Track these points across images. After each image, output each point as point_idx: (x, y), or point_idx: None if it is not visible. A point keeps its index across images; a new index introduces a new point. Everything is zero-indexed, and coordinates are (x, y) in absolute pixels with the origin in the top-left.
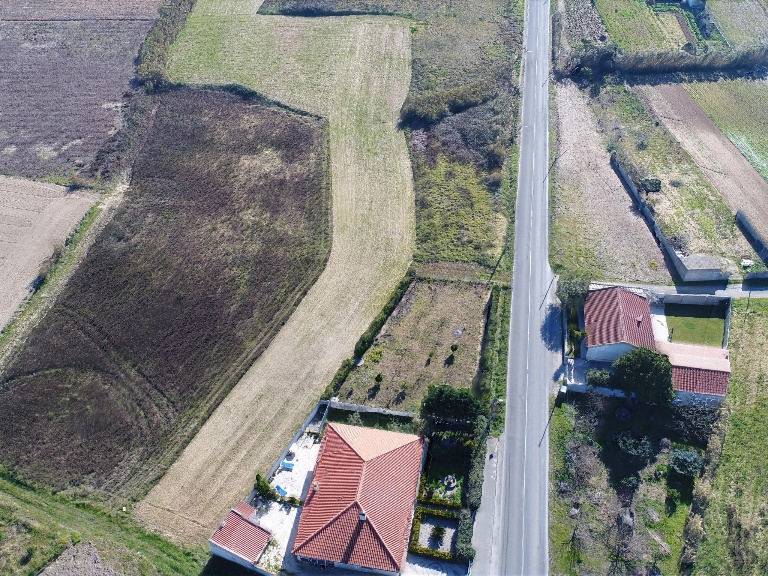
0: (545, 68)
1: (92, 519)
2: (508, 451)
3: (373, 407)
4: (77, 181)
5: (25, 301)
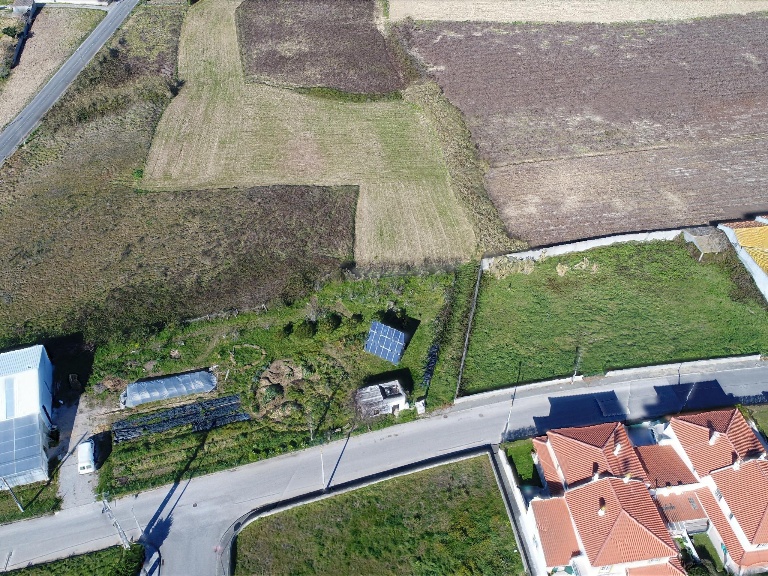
0: (2, 137)
1: None
2: None
3: None
4: None
5: None
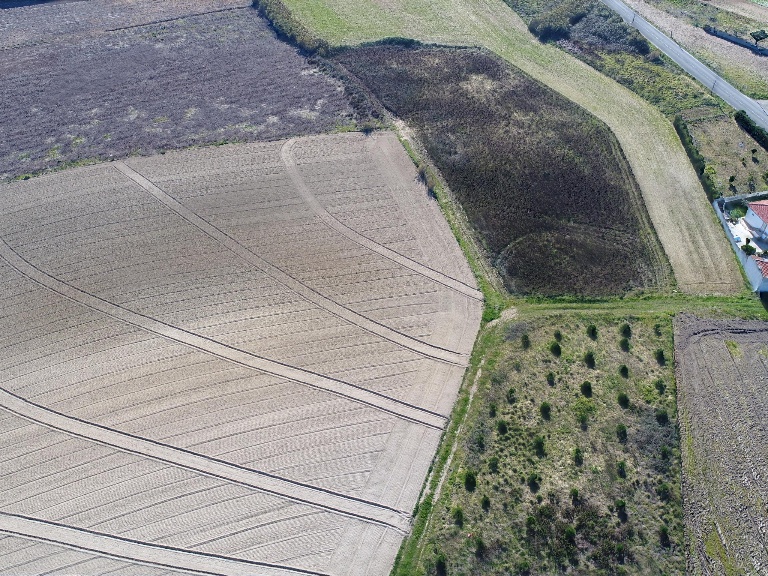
0: None
1: (664, 302)
2: None
3: None
4: (369, 124)
5: (439, 207)
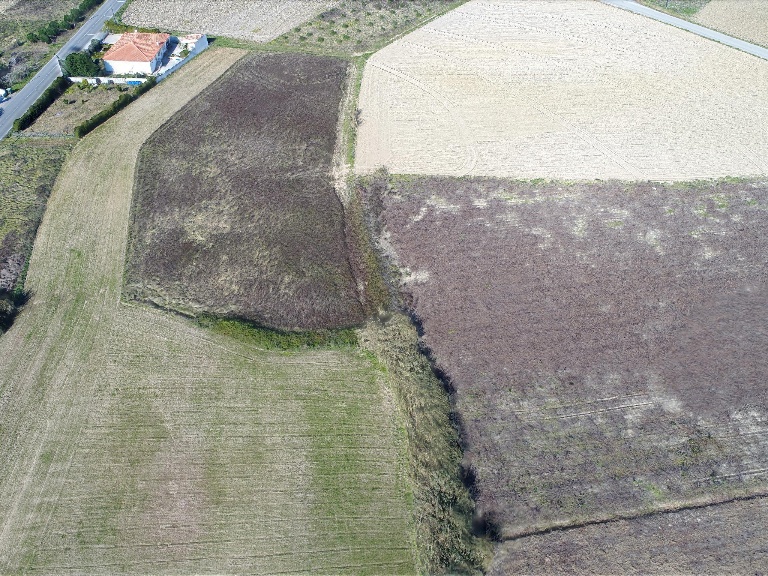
0: None
1: None
2: None
3: (127, 85)
4: None
5: None
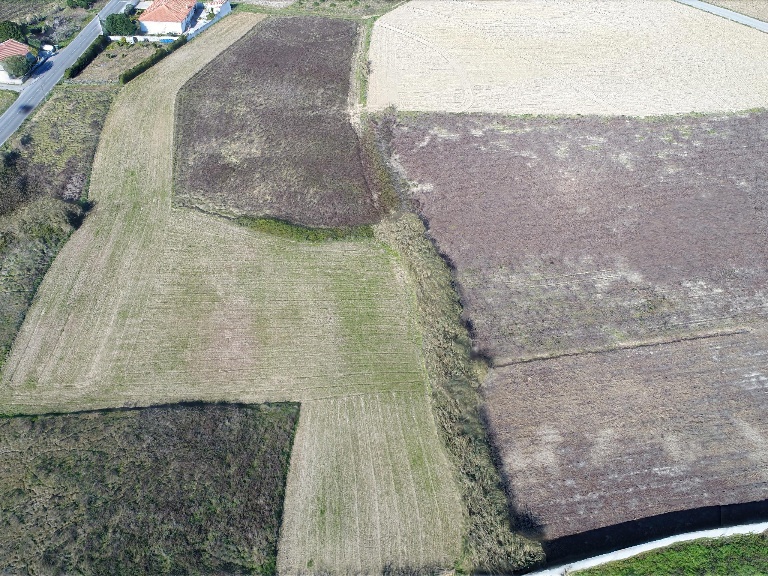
0: None
1: None
2: (99, 33)
3: (161, 43)
4: None
5: None
